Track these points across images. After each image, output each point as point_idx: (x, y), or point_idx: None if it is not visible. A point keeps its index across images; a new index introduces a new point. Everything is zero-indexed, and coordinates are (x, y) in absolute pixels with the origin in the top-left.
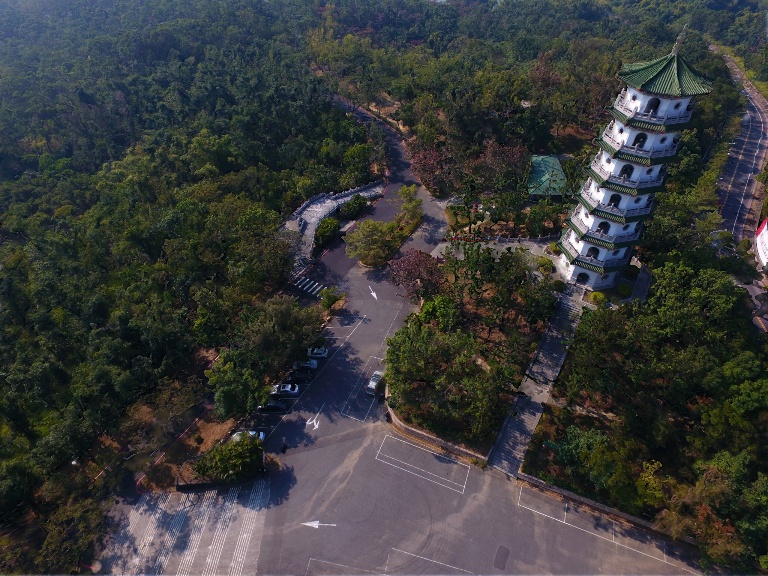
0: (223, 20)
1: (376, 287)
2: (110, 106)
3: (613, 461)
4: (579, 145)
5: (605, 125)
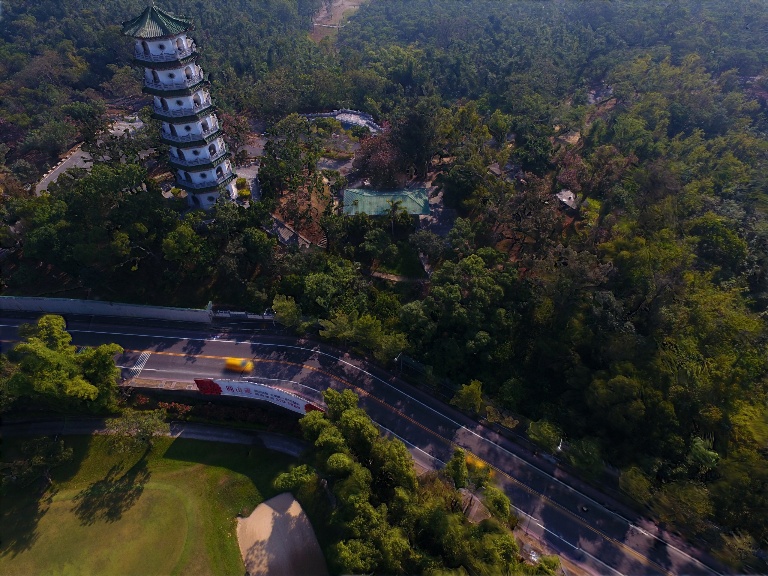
0: (666, 16)
1: (262, 146)
2: (483, 31)
3: (58, 180)
4: (483, 246)
5: (457, 219)
